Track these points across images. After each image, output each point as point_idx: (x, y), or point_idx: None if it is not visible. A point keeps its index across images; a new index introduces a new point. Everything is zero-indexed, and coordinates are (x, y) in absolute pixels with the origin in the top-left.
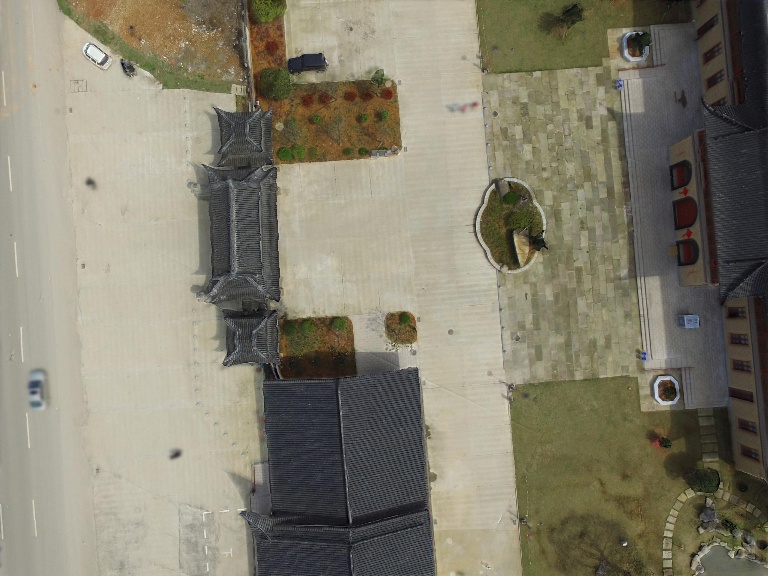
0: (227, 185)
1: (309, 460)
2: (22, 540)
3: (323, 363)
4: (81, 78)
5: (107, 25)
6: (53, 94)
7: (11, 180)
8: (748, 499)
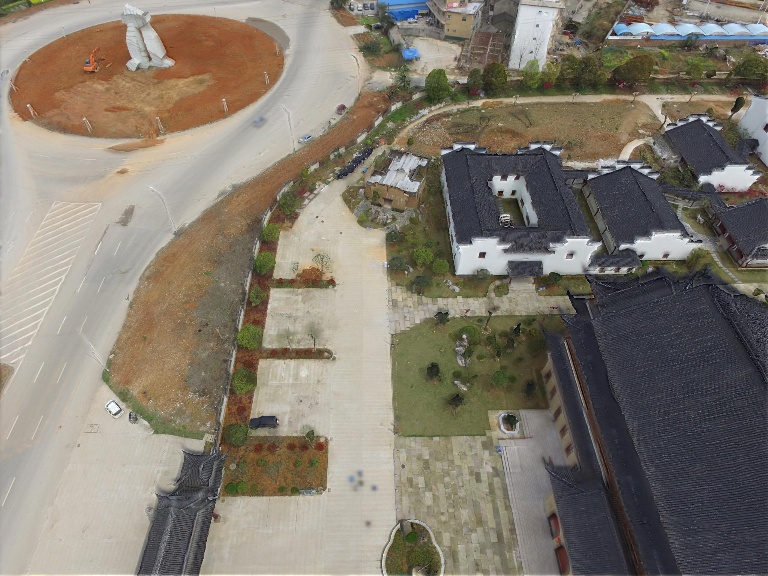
0: (168, 512)
1: None
2: None
3: None
4: (97, 423)
5: (130, 390)
6: (71, 433)
7: (7, 496)
8: None
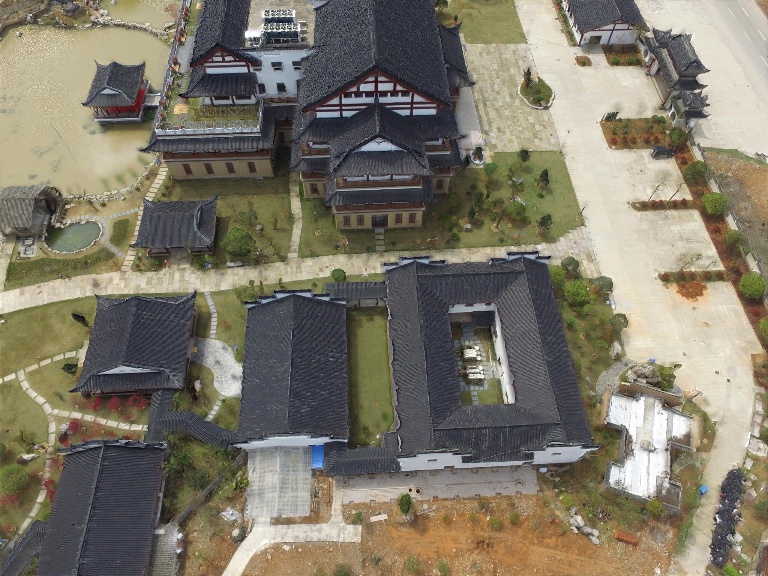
0: None
1: (624, 4)
2: (734, 7)
3: (619, 50)
4: None
5: None
6: None
7: None
8: None
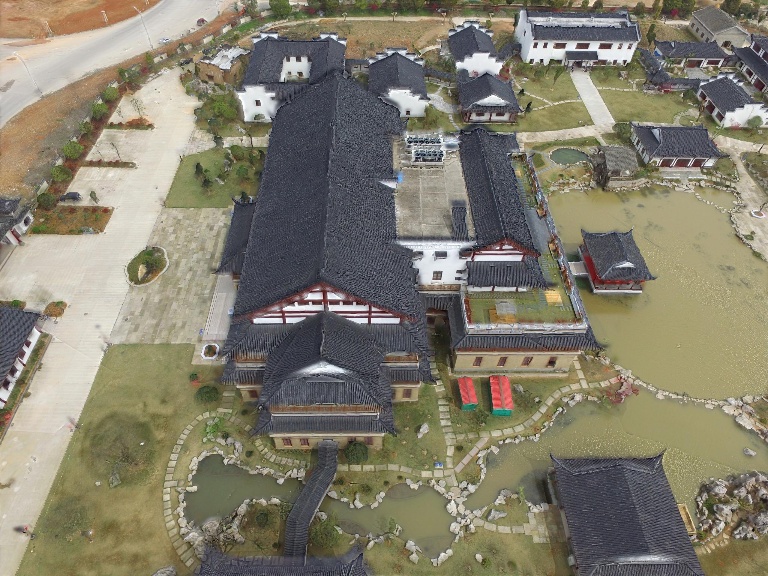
0: None
1: None
2: None
3: None
4: None
5: None
6: None
7: None
8: (248, 422)
